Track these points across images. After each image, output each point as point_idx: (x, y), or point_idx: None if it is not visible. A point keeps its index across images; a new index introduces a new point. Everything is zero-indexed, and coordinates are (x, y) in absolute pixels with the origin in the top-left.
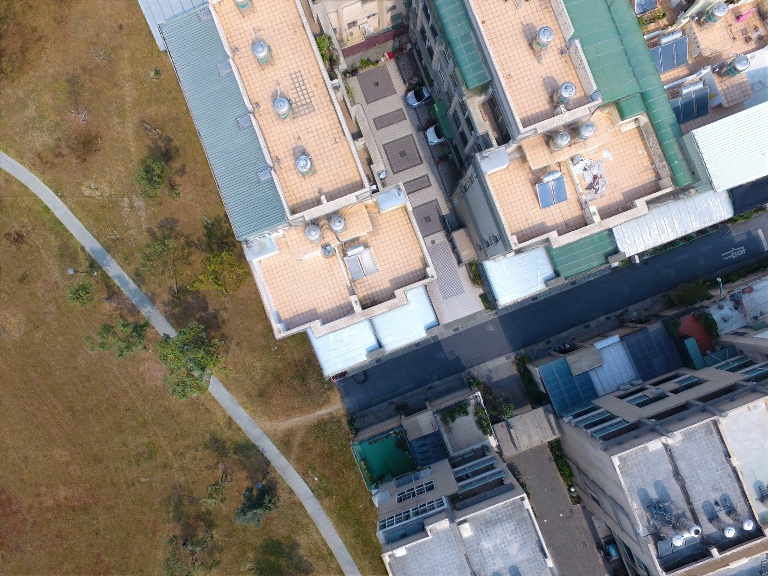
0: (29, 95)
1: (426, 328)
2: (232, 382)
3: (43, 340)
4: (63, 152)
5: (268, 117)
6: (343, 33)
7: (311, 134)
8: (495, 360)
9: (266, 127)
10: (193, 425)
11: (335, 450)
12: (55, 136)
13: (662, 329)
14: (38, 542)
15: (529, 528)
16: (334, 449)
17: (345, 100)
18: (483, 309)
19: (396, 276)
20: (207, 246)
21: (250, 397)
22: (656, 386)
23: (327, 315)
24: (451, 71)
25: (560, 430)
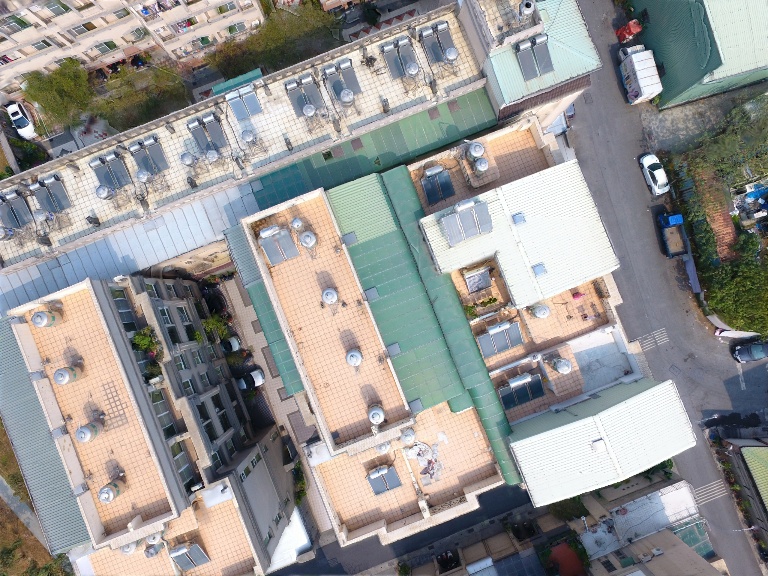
0: None
1: (297, 552)
2: None
3: None
4: None
5: None
6: None
7: (124, 447)
8: (378, 567)
9: None
10: None
11: None
12: None
13: (534, 555)
14: None
15: None
16: None
17: None
18: None
19: (228, 565)
20: None
21: None
22: None
23: None
24: None
25: None
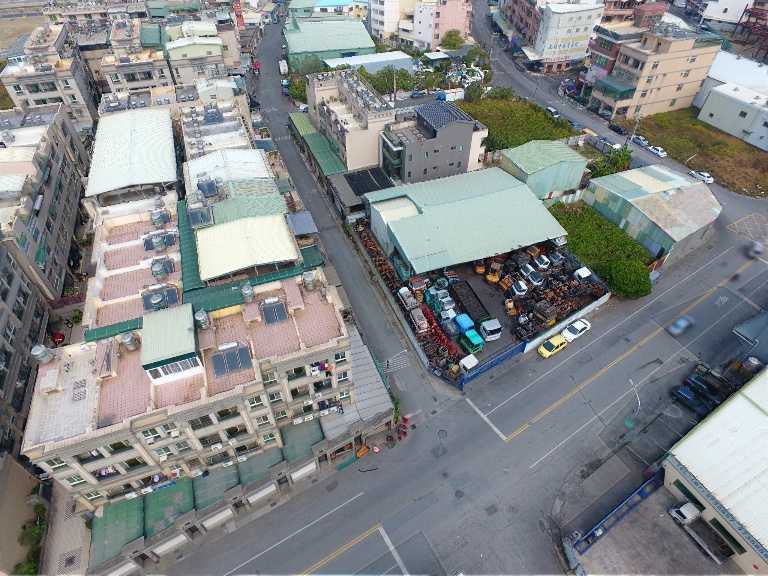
0: None
1: None
2: None
3: None
4: None
5: None
6: (102, 73)
7: None
8: None
9: None
10: None
11: None
12: None
13: None
14: None
15: None
16: None
17: None
18: None
19: None
20: None
21: None
22: None
23: None
24: None
25: None
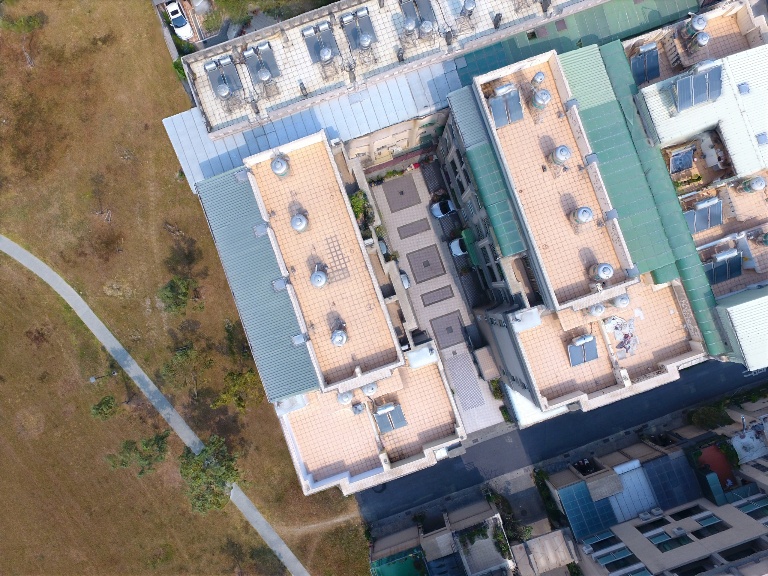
0: (53, 192)
1: (447, 448)
2: (250, 486)
3: (62, 439)
4: (86, 251)
5: (303, 281)
6: (372, 155)
7: (346, 300)
8: (513, 472)
9: (301, 291)
10: (210, 529)
11: (352, 558)
12: (78, 235)
13: (683, 457)
14: None
15: None
16: (351, 557)
17: (379, 257)
18: (503, 421)
19: (425, 430)
20: (228, 349)
21: (268, 502)
22: (677, 521)
23: (355, 467)
24: (483, 216)
25: (579, 554)
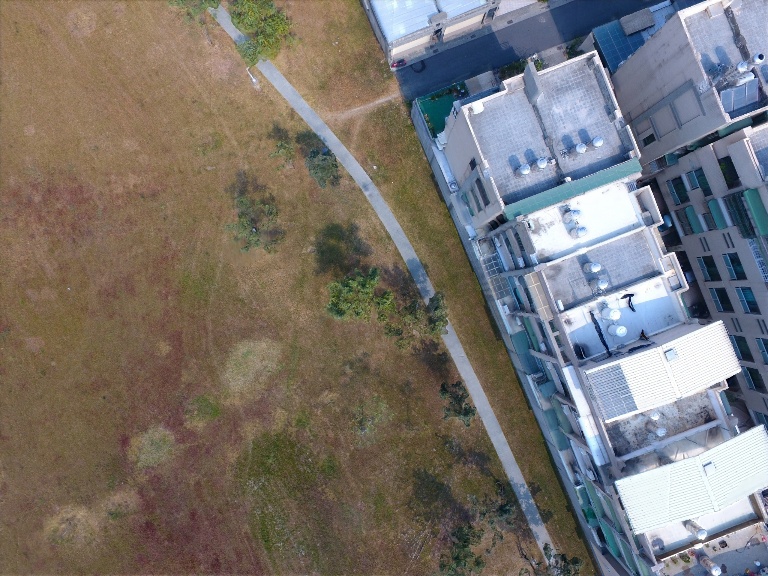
0: None
1: None
2: (294, 75)
3: (113, 36)
4: None
5: None
6: None
7: None
8: (547, 51)
9: None
10: (257, 116)
11: (393, 137)
12: None
13: None
14: (108, 227)
15: (598, 95)
16: (393, 136)
17: None
18: (536, 2)
19: None
20: None
21: (312, 89)
22: None
23: None
24: None
25: None
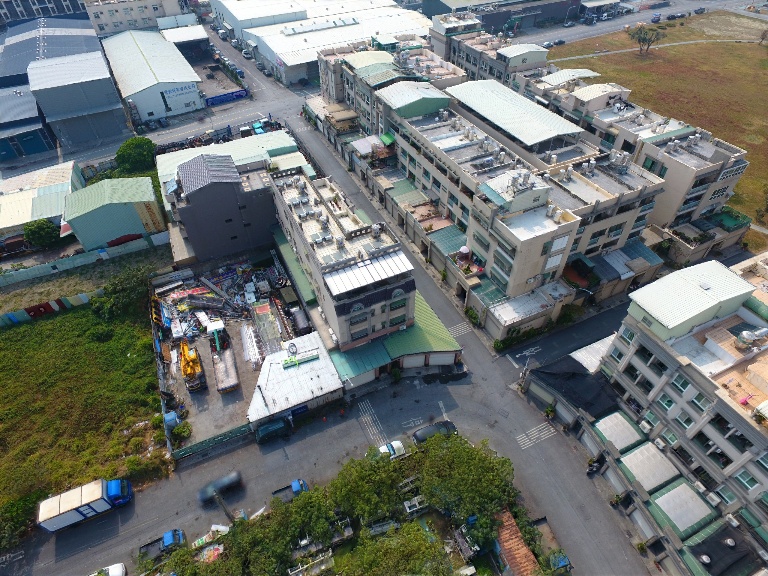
0: None
1: None
2: None
3: None
4: None
5: None
6: None
7: None
8: None
9: None
10: None
11: None
12: None
13: None
14: None
15: None
16: None
17: None
18: None
19: None
20: None
21: None
22: None
23: None
24: None
25: None
